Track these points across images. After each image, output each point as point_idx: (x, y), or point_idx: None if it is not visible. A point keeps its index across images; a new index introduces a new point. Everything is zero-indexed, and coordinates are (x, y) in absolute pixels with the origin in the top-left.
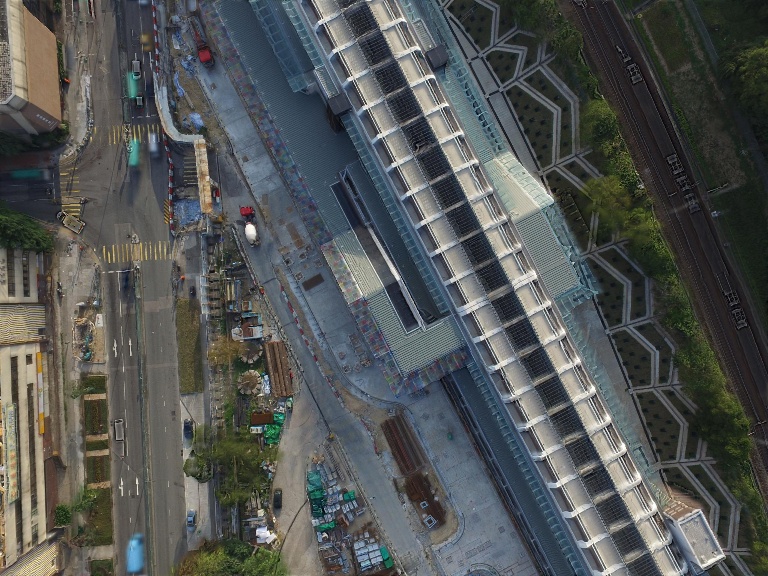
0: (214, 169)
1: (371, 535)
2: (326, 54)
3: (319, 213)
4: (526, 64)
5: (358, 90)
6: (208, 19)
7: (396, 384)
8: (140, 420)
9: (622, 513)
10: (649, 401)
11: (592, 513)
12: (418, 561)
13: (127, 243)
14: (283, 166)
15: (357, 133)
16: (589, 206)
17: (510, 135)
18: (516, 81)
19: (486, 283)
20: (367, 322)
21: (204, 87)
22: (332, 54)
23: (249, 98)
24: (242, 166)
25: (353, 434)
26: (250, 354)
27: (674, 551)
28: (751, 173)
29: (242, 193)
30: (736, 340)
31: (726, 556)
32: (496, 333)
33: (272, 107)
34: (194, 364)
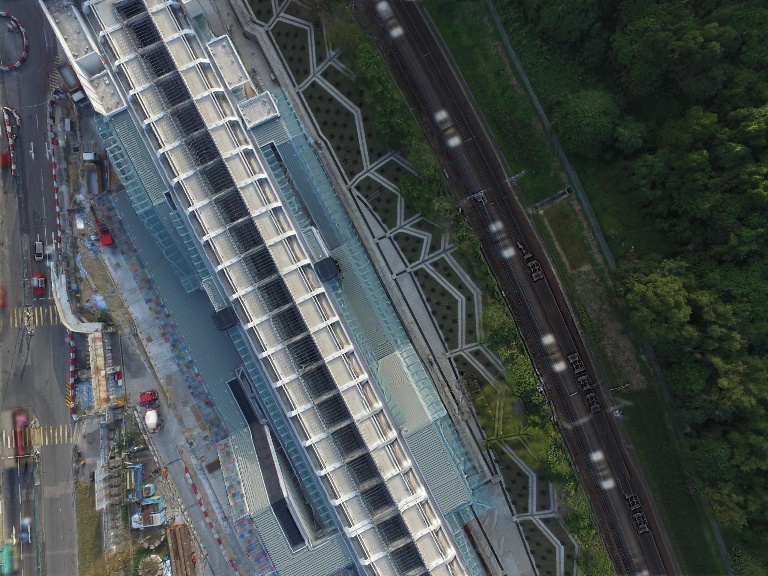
0: (117, 350)
1: None
2: (213, 267)
3: (215, 409)
4: (431, 249)
5: (244, 306)
6: (104, 212)
7: None
8: None
9: None
10: None
11: None
12: None
13: (27, 427)
14: (179, 362)
15: (245, 346)
16: (494, 395)
17: (417, 316)
18: (423, 263)
19: (371, 507)
20: (253, 541)
21: (108, 267)
22: (217, 270)
23: (145, 292)
24: (146, 346)
25: None
26: (151, 540)
27: None
28: (651, 378)
29: (145, 374)
30: (637, 545)
31: None
32: (382, 557)
33: (168, 301)
34: (94, 551)
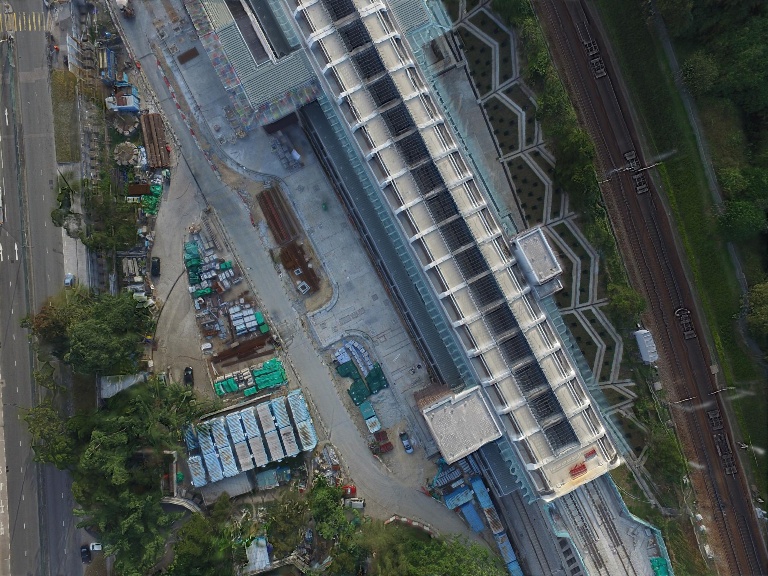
0: None
1: (247, 303)
2: None
3: None
4: None
5: None
6: None
7: (247, 116)
8: (18, 188)
9: (464, 233)
10: (518, 167)
11: (435, 234)
12: (294, 329)
13: (1, 13)
14: None
15: None
16: None
17: None
18: None
19: (331, 8)
20: (218, 55)
21: None
22: None
23: None
24: None
25: (230, 207)
26: (126, 125)
27: (518, 276)
28: None
29: None
30: (594, 89)
31: (587, 311)
32: (343, 61)
33: None
34: (70, 134)
